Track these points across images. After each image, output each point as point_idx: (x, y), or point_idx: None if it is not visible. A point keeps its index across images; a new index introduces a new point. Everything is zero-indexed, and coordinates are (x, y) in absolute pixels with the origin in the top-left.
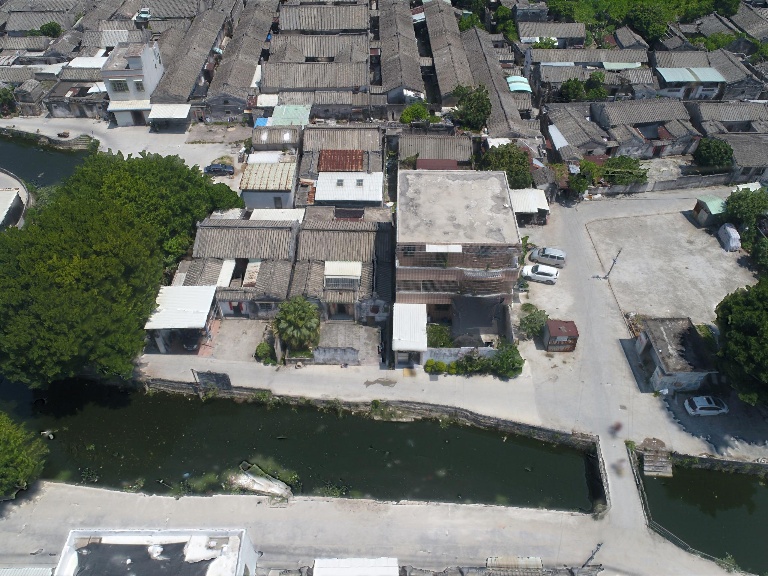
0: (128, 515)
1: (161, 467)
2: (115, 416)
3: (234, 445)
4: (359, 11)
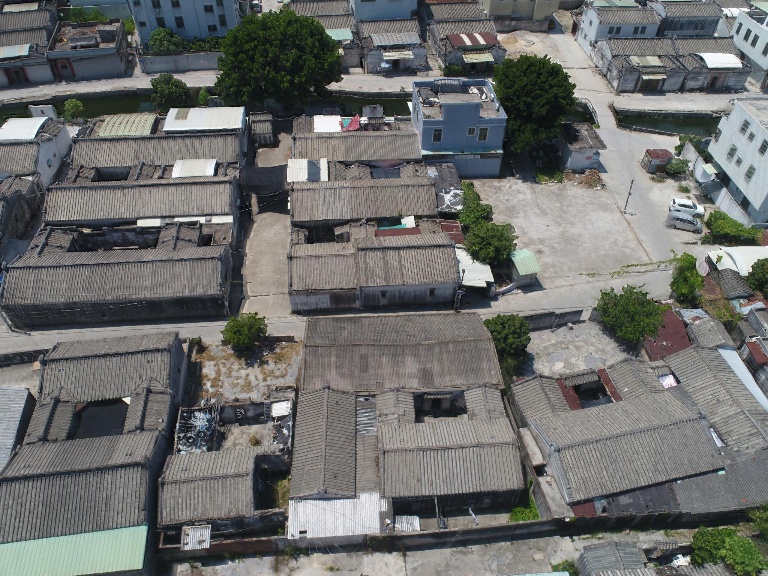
0: None
1: None
2: None
3: None
4: None
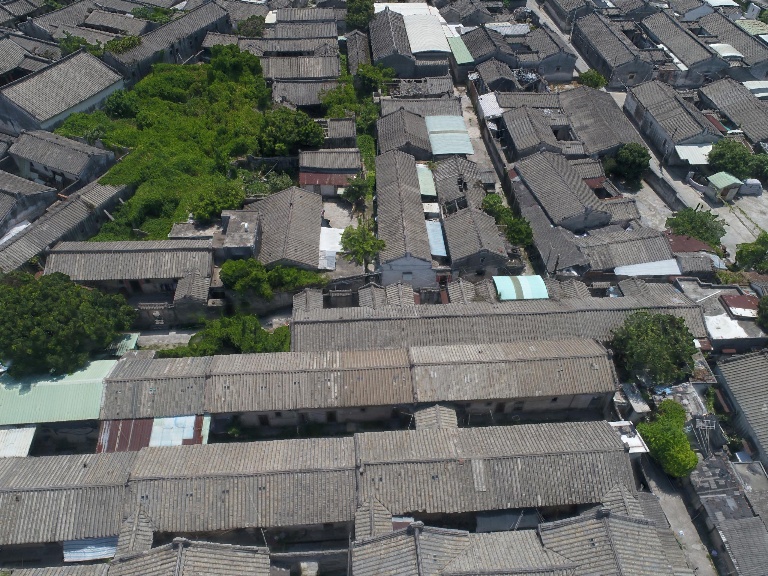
0: None
1: None
2: None
3: None
4: (199, 575)
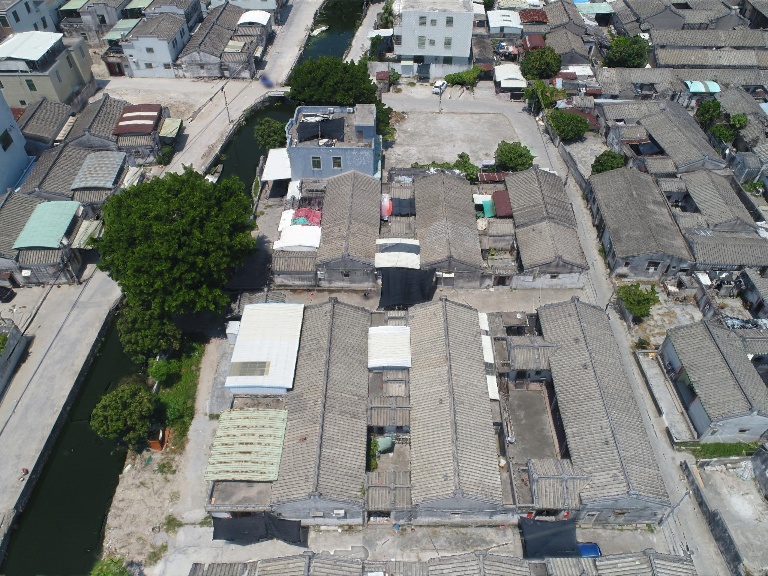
0: (310, 7)
1: None
2: (358, 7)
3: (338, 25)
4: None
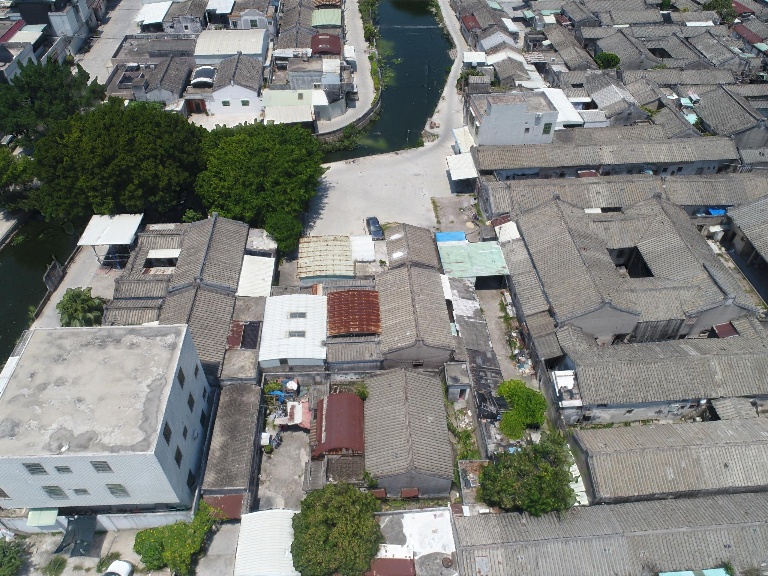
0: None
1: (6, 272)
2: None
3: (4, 308)
4: None
